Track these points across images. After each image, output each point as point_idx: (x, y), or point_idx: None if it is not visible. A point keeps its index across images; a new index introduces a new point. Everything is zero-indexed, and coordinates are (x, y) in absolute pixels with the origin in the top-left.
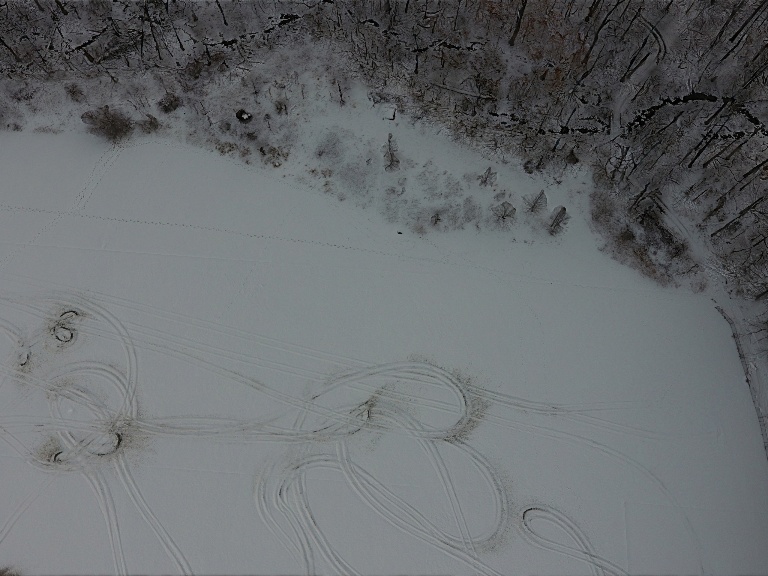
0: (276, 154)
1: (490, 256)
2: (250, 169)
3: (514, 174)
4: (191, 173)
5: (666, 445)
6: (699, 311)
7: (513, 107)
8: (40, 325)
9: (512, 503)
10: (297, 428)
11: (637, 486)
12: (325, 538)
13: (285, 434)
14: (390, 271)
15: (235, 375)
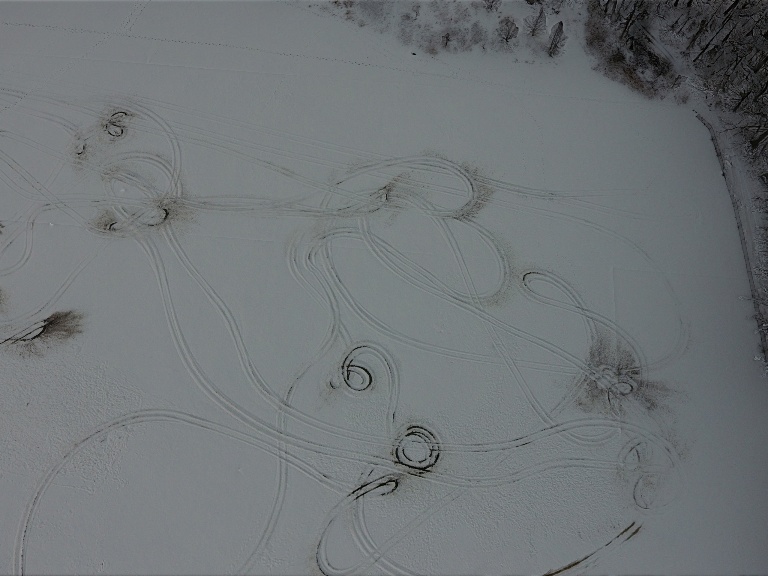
0: None
1: (495, 73)
2: (279, 0)
3: (517, 4)
4: (226, 3)
5: (650, 224)
6: (682, 119)
7: None
8: (94, 123)
9: (514, 268)
10: (323, 207)
11: (624, 256)
12: (349, 292)
13: (313, 211)
14: (405, 84)
15: (268, 164)
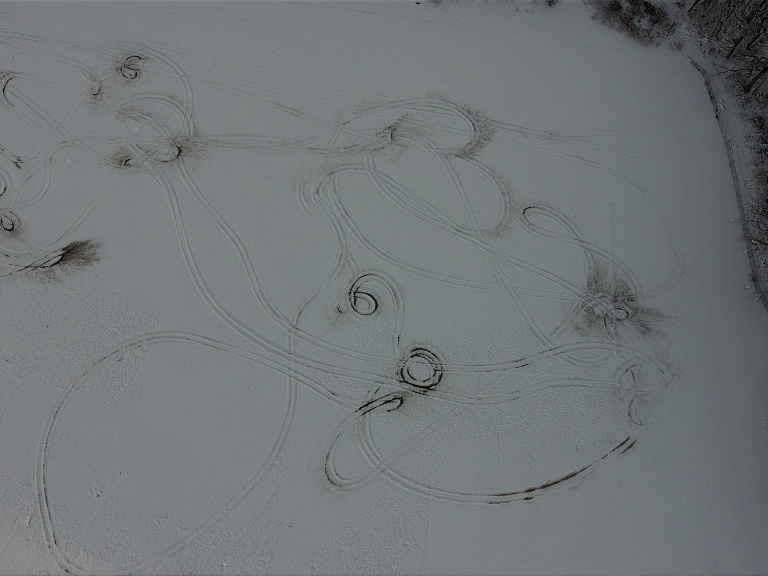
0: None
1: (496, 21)
2: None
3: None
4: None
5: (646, 163)
6: (676, 65)
7: None
8: (109, 66)
9: (514, 202)
10: (331, 145)
11: (620, 192)
12: (356, 224)
13: (321, 149)
14: (409, 31)
15: (277, 105)
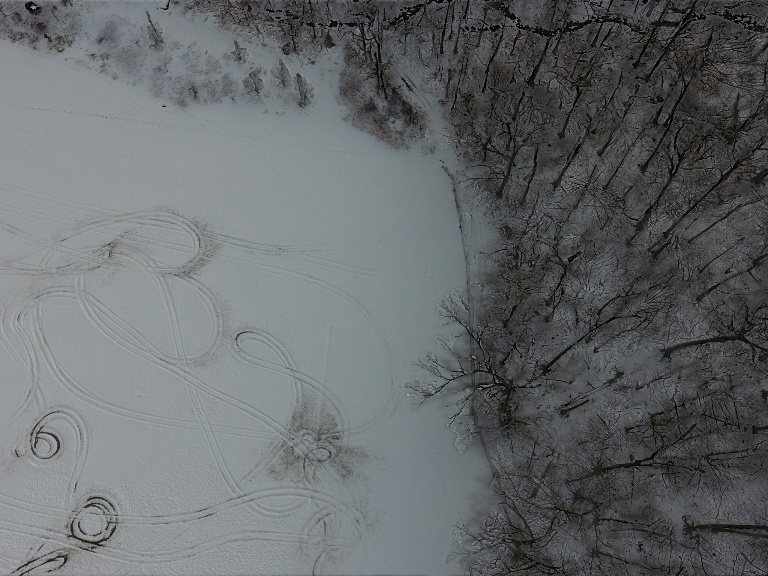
0: (62, 41)
1: (243, 125)
2: (37, 54)
3: (272, 55)
4: None
5: (376, 280)
6: (427, 170)
7: (287, 4)
8: None
9: (227, 327)
10: (43, 265)
11: (344, 313)
12: (53, 354)
13: (31, 270)
14: (149, 137)
15: None
